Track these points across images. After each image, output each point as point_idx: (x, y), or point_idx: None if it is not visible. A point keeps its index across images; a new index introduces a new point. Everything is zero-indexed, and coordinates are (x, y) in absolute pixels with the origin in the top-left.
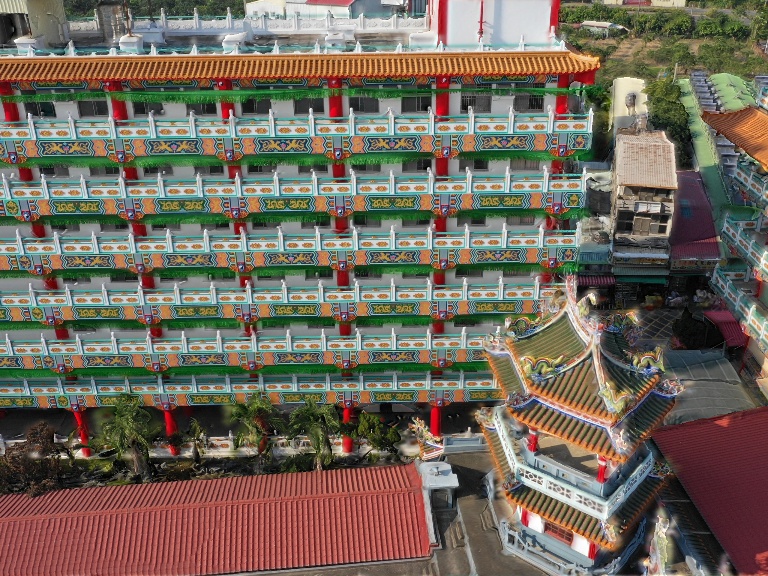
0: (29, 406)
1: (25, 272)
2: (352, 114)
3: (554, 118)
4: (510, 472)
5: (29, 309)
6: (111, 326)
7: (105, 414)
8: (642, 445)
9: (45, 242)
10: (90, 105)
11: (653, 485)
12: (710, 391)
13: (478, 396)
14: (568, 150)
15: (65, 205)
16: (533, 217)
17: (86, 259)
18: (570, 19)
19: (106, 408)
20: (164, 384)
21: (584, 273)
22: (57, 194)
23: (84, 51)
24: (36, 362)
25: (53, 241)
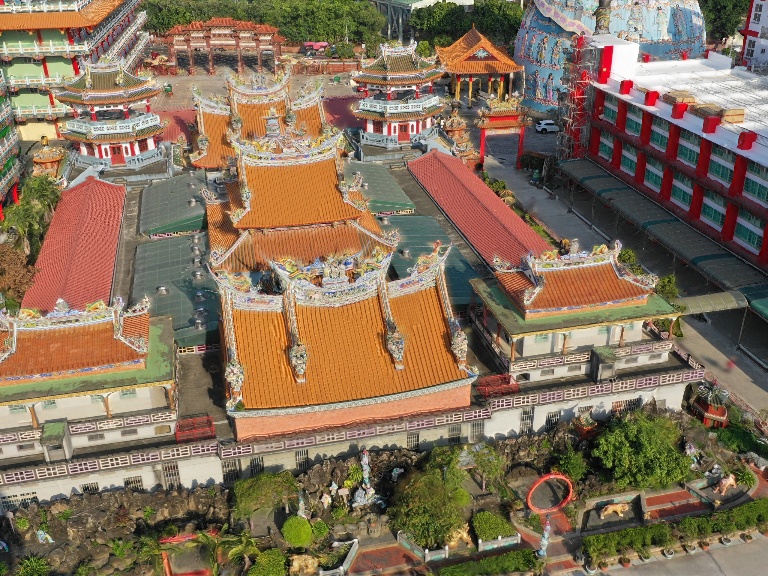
0: None
1: None
2: None
3: None
4: (124, 135)
5: None
6: None
7: None
8: None
9: None
10: None
11: None
12: None
13: None
14: None
15: None
16: None
17: None
18: None
19: None
20: None
21: None
22: None
23: None
24: None
25: None
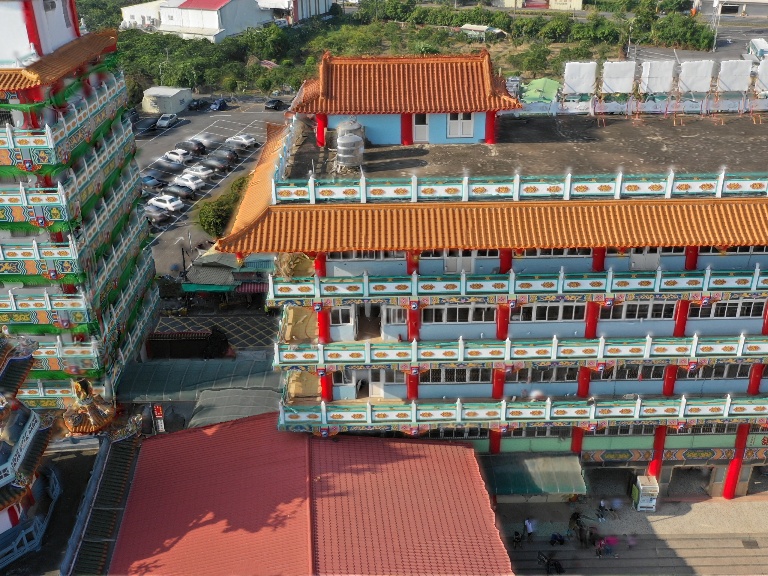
0: None
1: None
2: None
3: (12, 134)
4: None
5: None
6: None
7: None
8: (7, 455)
9: None
10: None
11: (13, 494)
12: (245, 399)
13: (27, 404)
14: (35, 165)
15: None
16: (37, 229)
17: None
18: (454, 23)
19: None
20: None
21: (256, 280)
22: None
23: None
24: None
25: None
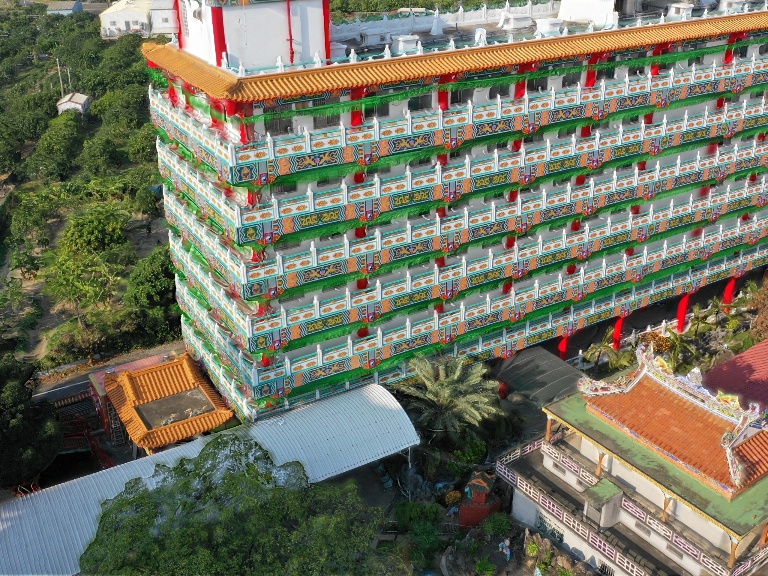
0: (670, 296)
1: (712, 180)
2: None
3: None
4: None
5: (706, 210)
6: (739, 214)
7: (705, 291)
8: None
9: (729, 153)
10: (764, 46)
11: None
12: None
13: None
14: None
15: (751, 121)
16: None
17: (747, 162)
18: (381, 8)
19: (710, 285)
20: (743, 256)
21: None
22: (748, 114)
23: (694, 13)
24: (695, 254)
25: (734, 152)
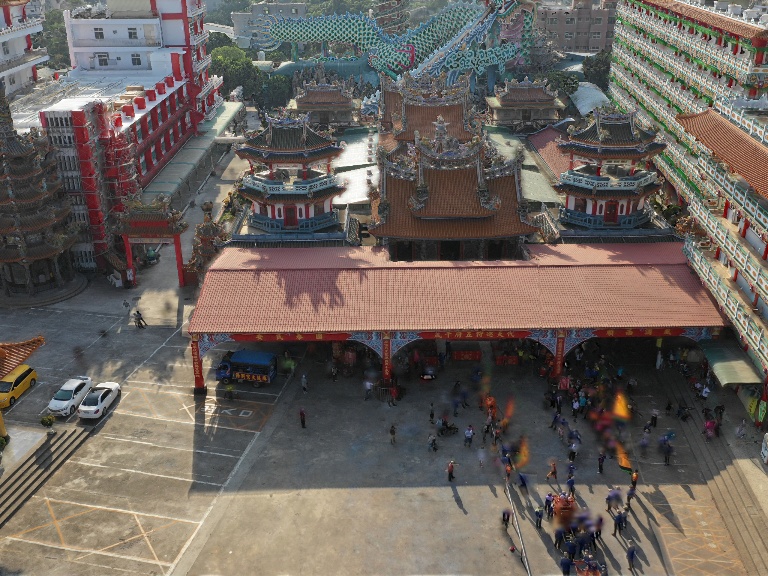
0: None
1: None
2: (713, 45)
3: None
4: None
5: None
6: None
7: None
8: None
9: None
10: None
11: (590, 194)
12: None
13: None
14: None
15: None
16: None
17: None
18: None
19: None
20: None
21: None
22: None
23: None
24: None
25: None
